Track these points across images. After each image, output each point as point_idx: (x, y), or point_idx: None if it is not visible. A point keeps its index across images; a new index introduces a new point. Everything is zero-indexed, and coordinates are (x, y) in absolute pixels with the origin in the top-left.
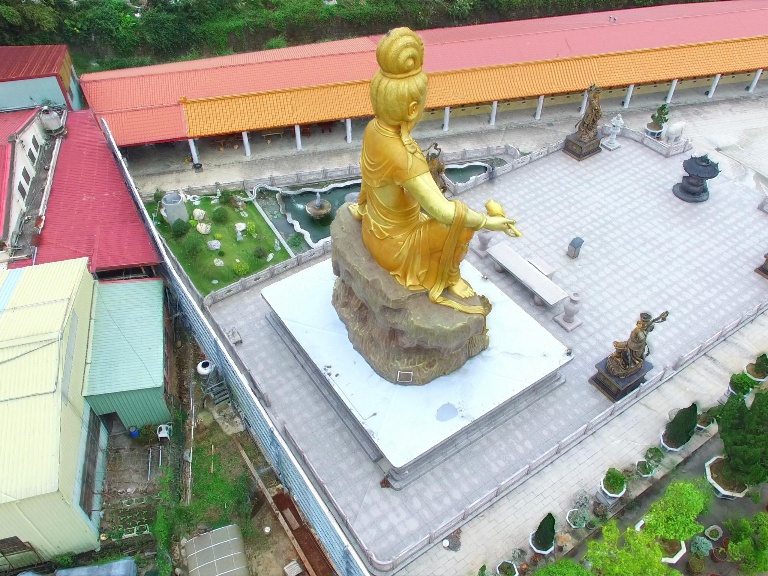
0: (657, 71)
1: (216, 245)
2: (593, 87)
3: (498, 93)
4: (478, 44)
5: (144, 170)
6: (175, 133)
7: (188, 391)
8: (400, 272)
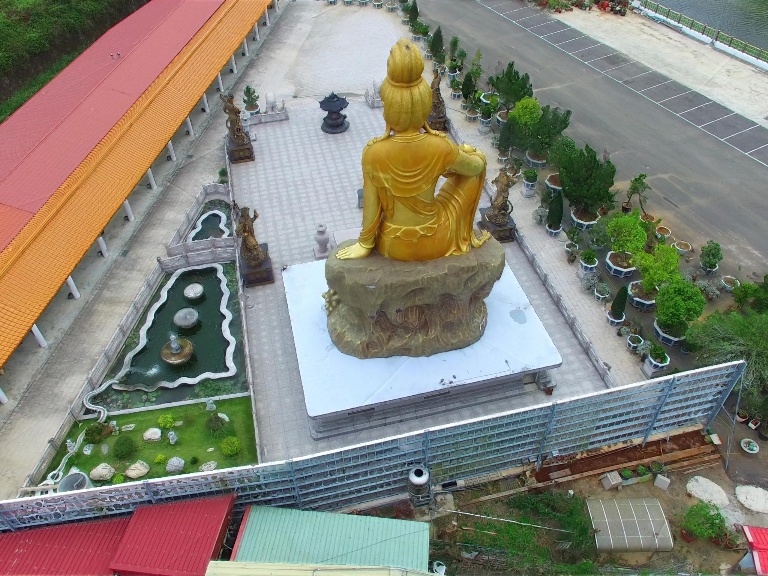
0: (208, 70)
1: (180, 461)
2: (227, 96)
3: (148, 155)
4: (57, 136)
5: None
6: None
7: None
8: (455, 247)
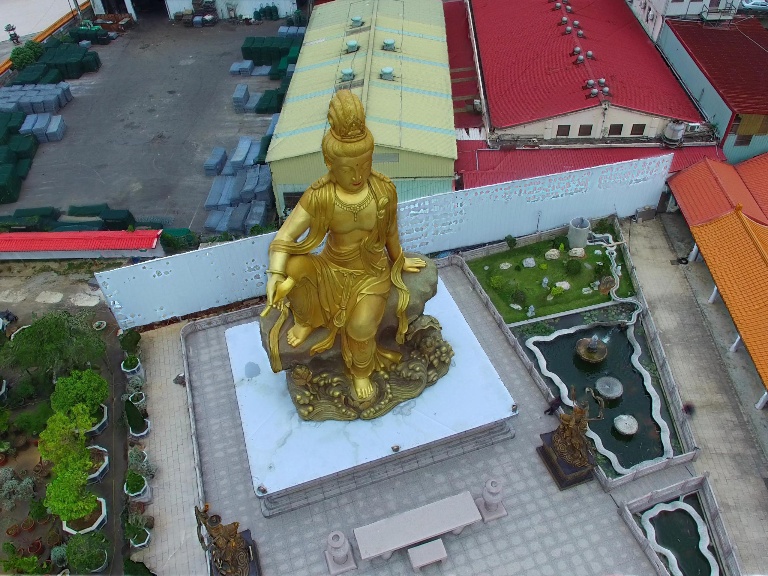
0: None
1: (527, 262)
2: None
3: None
4: None
5: (673, 224)
6: (693, 217)
7: None
8: None
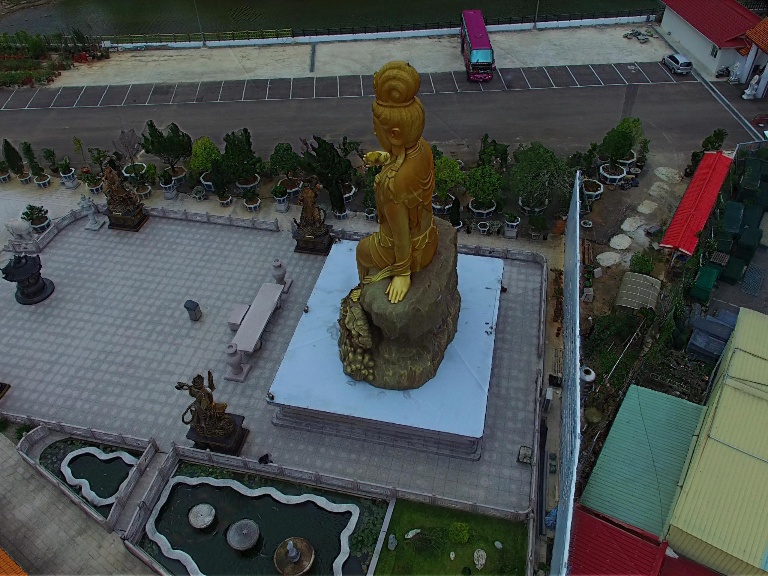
0: None
1: None
2: None
3: None
4: None
5: None
6: None
7: (595, 451)
8: None
